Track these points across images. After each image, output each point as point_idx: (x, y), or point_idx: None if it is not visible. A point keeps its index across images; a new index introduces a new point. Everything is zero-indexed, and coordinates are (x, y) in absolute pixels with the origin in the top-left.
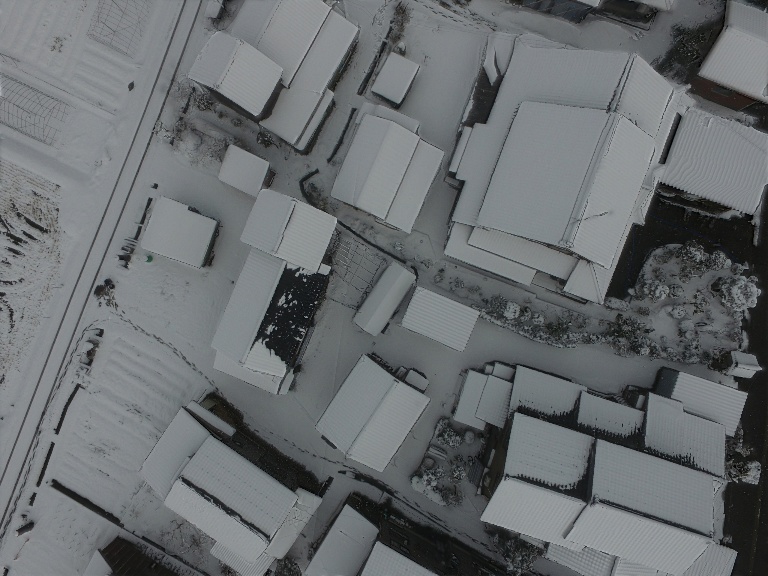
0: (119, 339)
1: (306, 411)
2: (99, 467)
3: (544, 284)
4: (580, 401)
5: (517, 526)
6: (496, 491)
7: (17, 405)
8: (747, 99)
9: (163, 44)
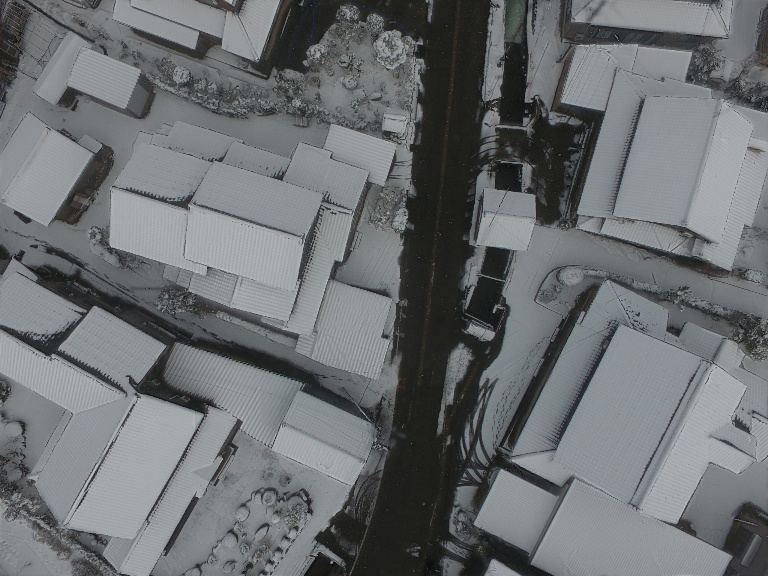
0: None
1: None
2: None
3: (226, 60)
4: (229, 148)
5: (143, 249)
6: (111, 208)
7: None
8: None
9: None
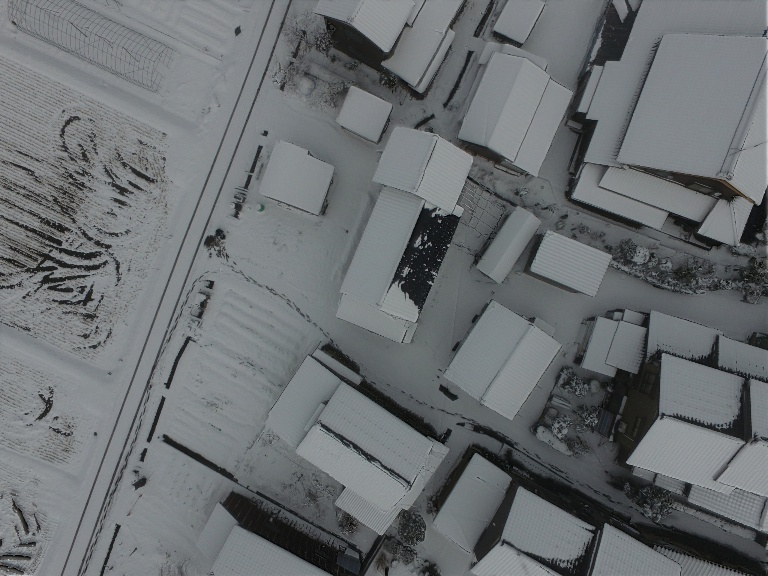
0: (230, 291)
1: (439, 357)
2: (211, 422)
3: (668, 230)
4: (719, 345)
5: (665, 468)
6: (648, 432)
7: (126, 359)
8: None
9: None
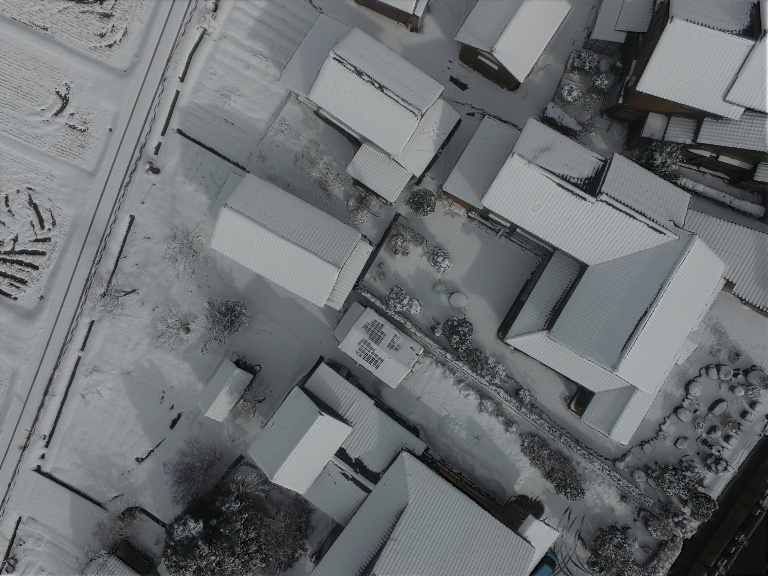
0: None
1: (450, 7)
2: (224, 115)
3: None
4: None
5: (675, 91)
6: (658, 43)
7: (142, 53)
8: None
9: None
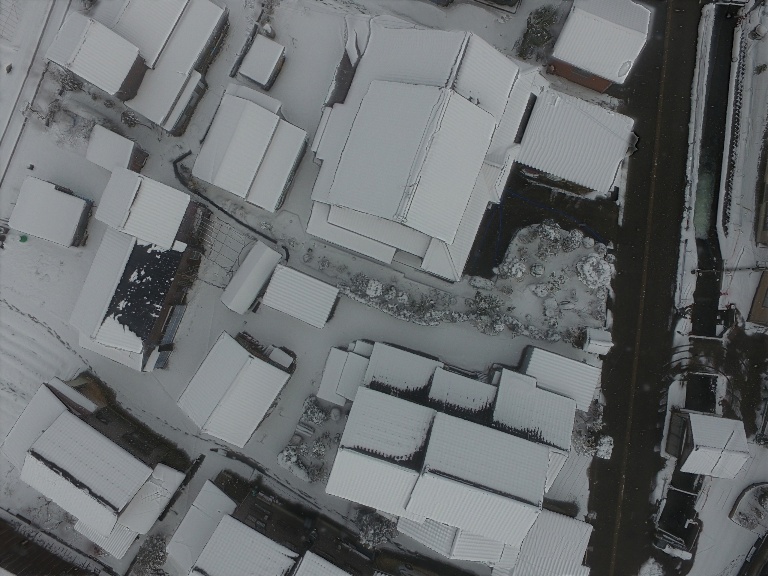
0: None
1: (163, 387)
2: None
3: (412, 263)
4: (433, 376)
5: (360, 498)
6: (335, 463)
7: None
8: (603, 80)
9: (39, 27)
